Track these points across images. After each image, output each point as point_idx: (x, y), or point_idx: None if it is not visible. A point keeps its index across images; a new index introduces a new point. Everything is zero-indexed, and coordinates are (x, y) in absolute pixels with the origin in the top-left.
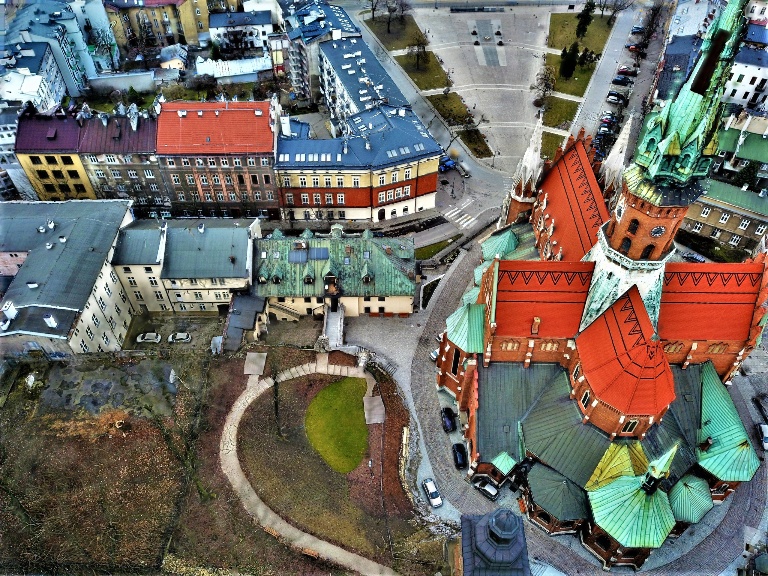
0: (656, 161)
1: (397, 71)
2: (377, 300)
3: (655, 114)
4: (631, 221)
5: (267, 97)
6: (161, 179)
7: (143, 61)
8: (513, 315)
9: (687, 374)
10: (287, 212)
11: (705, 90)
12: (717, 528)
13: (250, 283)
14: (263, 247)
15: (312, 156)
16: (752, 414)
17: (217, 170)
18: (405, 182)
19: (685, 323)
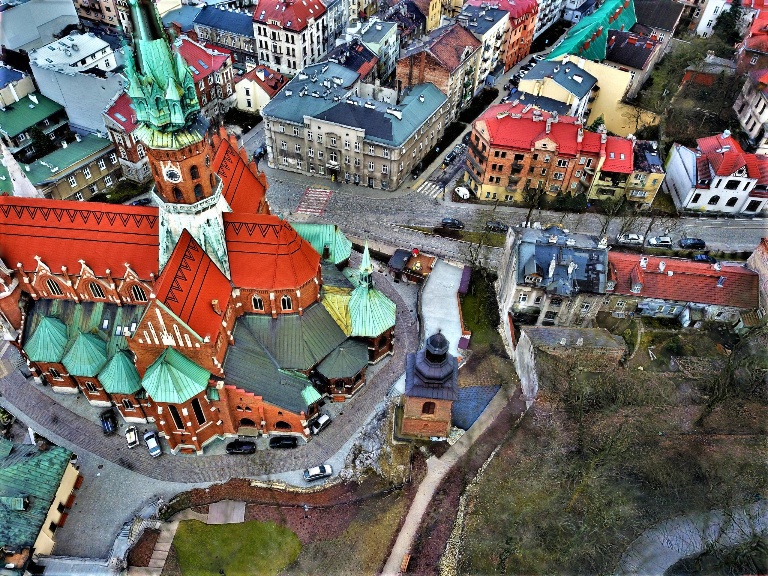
0: (176, 110)
1: None
2: None
3: None
4: (190, 171)
5: None
6: None
7: None
8: (202, 320)
9: None
10: None
11: (161, 33)
12: None
13: None
14: None
15: None
16: None
17: None
18: None
19: (244, 211)
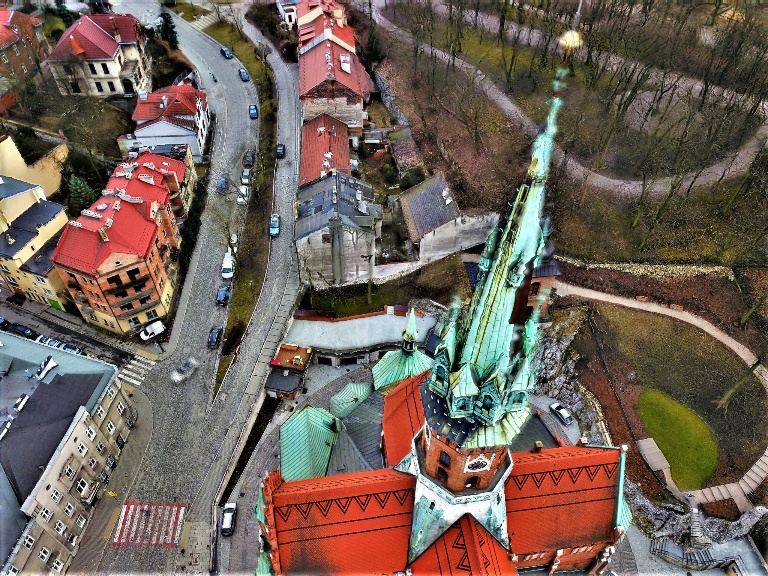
0: None
1: None
2: None
3: None
4: None
5: None
6: None
7: None
8: None
9: None
10: None
11: None
12: None
13: None
14: None
15: None
16: (228, 552)
17: None
18: None
19: None
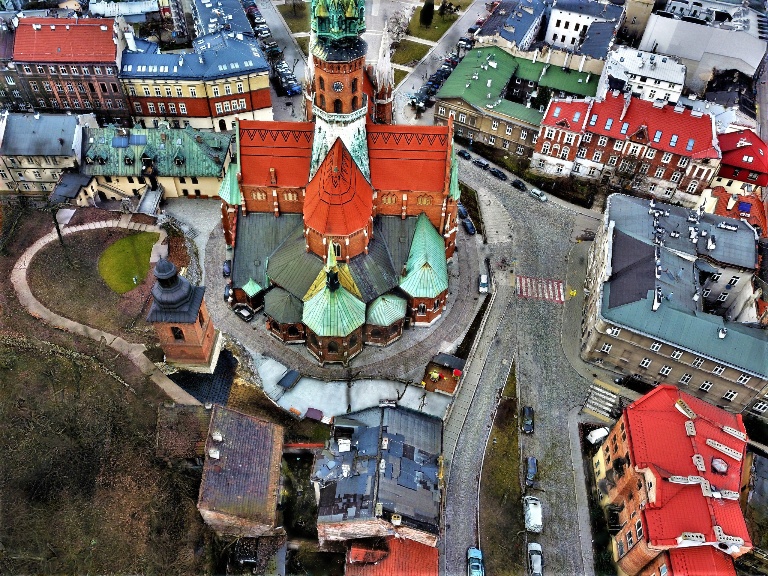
0: None
1: (276, 17)
2: (191, 182)
3: (477, 49)
4: (320, 79)
5: (151, 35)
6: (21, 85)
7: (43, 2)
8: (255, 167)
9: (406, 223)
10: (138, 120)
11: None
12: (421, 342)
13: (79, 163)
14: (91, 133)
15: (152, 67)
16: (481, 269)
17: (69, 78)
18: (239, 95)
19: (393, 176)
